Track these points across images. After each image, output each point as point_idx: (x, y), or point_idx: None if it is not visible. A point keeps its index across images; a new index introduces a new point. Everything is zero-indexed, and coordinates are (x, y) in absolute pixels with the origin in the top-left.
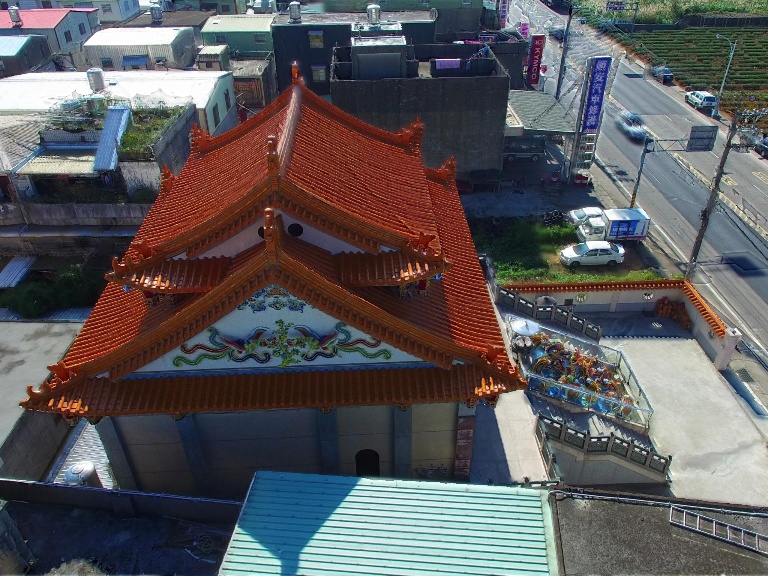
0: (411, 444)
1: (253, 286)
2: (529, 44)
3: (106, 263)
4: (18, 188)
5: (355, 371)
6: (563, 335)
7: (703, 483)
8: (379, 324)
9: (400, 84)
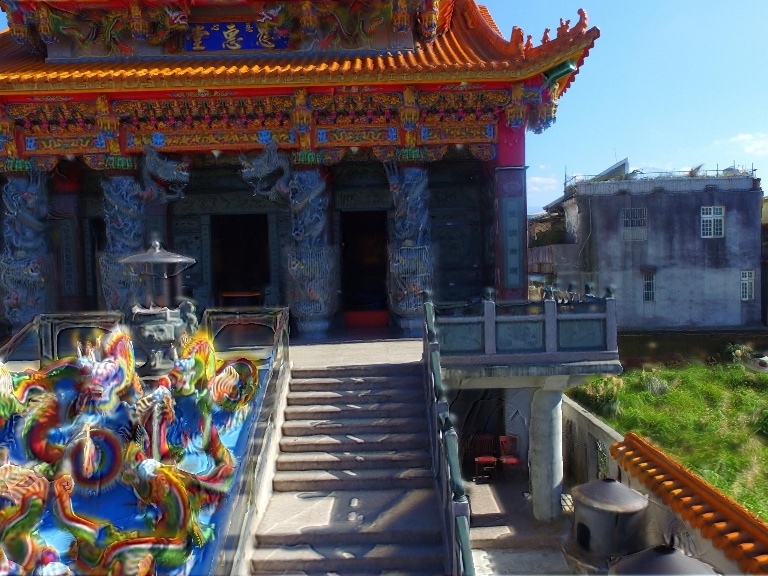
0: None
1: None
2: None
3: None
4: (533, 237)
5: None
6: (367, 549)
7: None
8: None
9: None
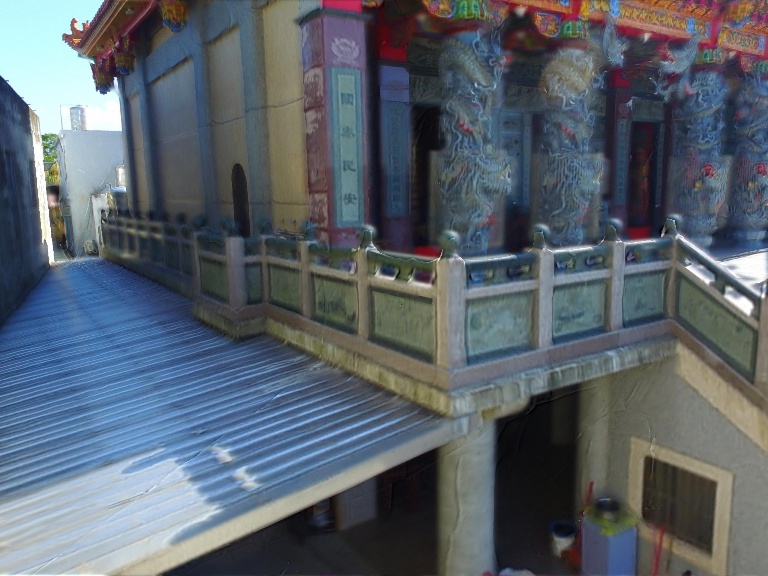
0: (269, 145)
1: None
2: None
3: None
4: None
5: None
6: None
7: None
8: None
9: None
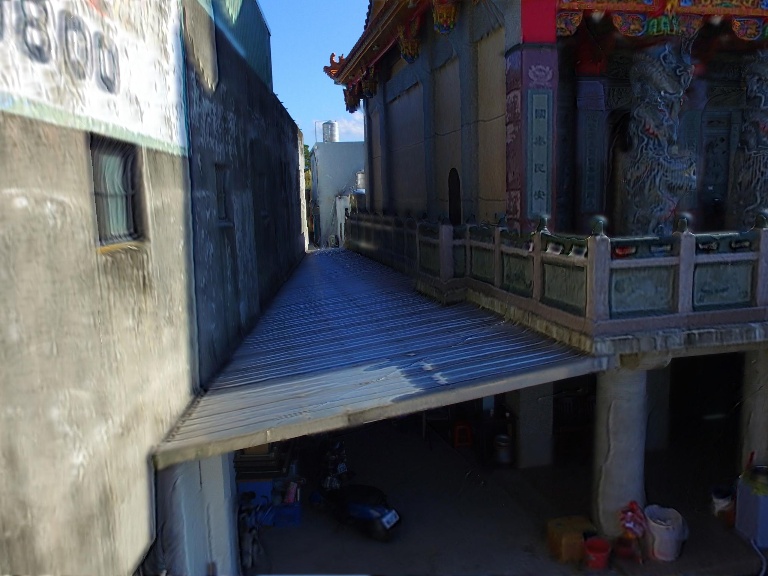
0: (479, 152)
1: None
2: None
3: None
4: None
5: None
6: None
7: None
8: None
9: None
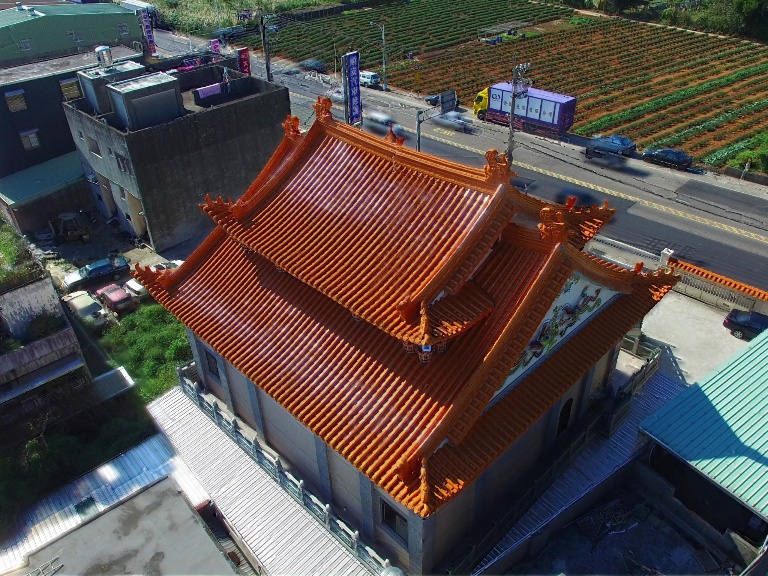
0: None
1: (560, 281)
2: (236, 59)
3: (19, 432)
4: None
5: (585, 328)
6: None
7: (655, 323)
8: (602, 277)
9: (195, 120)
